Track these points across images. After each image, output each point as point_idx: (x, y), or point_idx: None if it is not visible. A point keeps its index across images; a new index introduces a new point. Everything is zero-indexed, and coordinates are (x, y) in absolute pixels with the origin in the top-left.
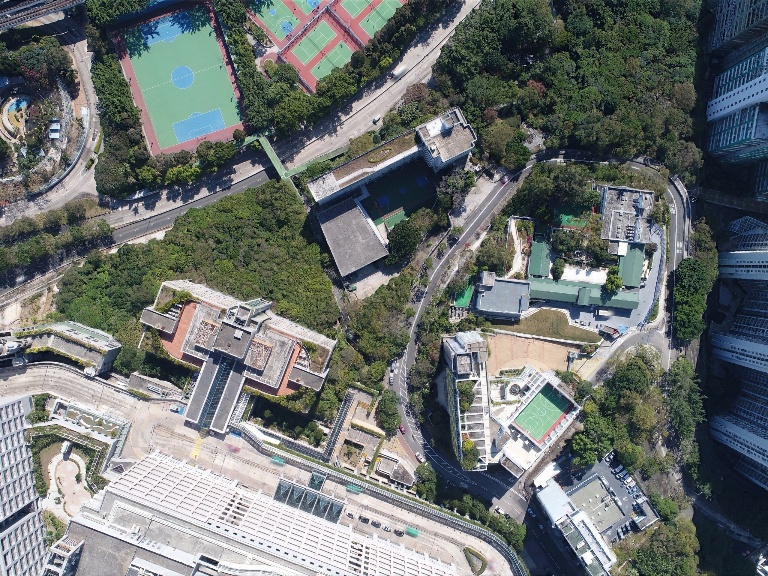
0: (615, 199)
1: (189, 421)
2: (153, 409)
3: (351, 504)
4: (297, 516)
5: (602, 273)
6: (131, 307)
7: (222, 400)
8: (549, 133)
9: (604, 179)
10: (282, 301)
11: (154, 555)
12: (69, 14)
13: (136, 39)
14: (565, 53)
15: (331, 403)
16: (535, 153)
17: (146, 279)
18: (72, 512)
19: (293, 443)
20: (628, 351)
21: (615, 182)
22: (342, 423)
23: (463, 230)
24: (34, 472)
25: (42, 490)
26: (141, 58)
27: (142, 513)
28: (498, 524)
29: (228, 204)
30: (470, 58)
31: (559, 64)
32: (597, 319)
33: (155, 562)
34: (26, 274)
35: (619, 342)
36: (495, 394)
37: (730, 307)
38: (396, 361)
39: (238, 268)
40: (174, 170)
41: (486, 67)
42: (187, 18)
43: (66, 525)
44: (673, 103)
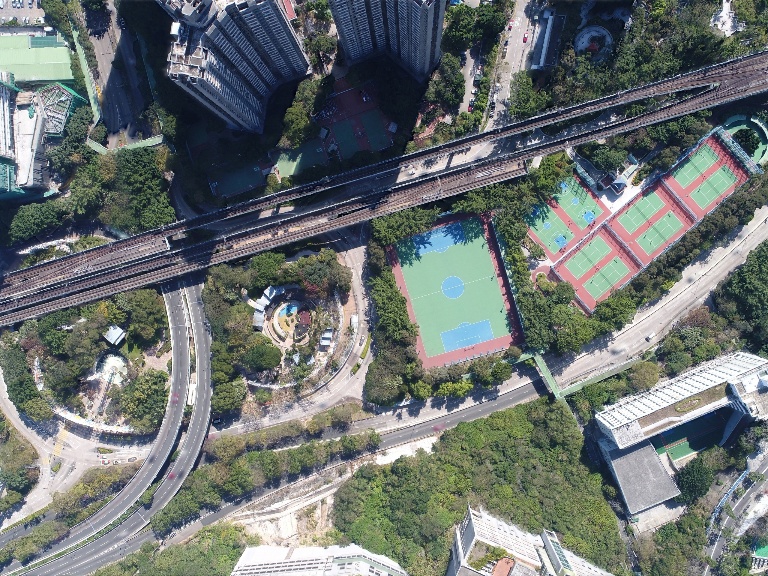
0: None
1: None
2: None
3: None
4: None
5: None
6: (421, 539)
7: None
8: None
9: None
10: (568, 535)
11: None
12: None
13: (408, 248)
14: None
15: None
16: None
17: (430, 505)
18: None
19: None
20: None
21: None
22: None
23: (759, 472)
24: None
25: None
26: (412, 267)
27: None
28: None
29: (501, 422)
30: (763, 290)
31: None
32: None
33: None
34: (290, 476)
35: None
36: None
37: None
38: None
39: (515, 491)
40: (450, 387)
41: None
42: (460, 229)
43: None
44: None
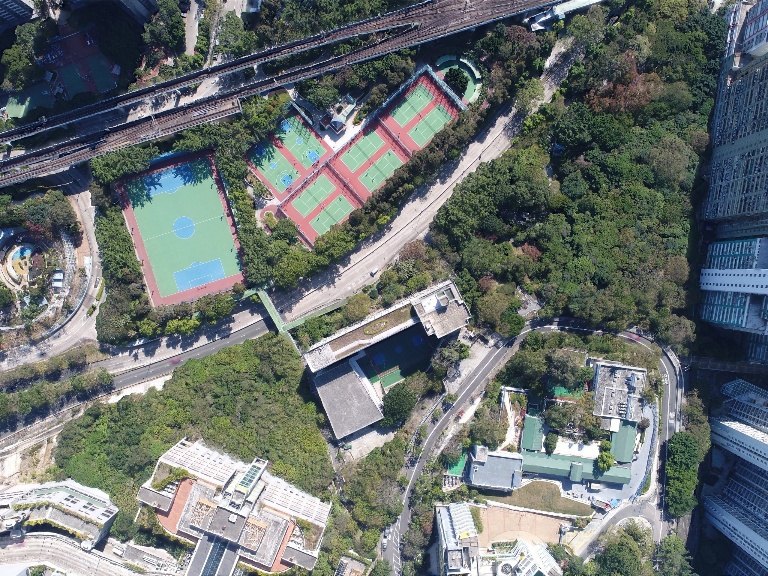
0: (608, 376)
1: None
2: None
3: None
4: None
5: (594, 447)
6: (129, 469)
7: None
8: (544, 300)
9: (597, 351)
10: (278, 462)
11: None
12: (74, 165)
13: (139, 190)
14: (560, 215)
15: (324, 571)
16: (529, 320)
17: (144, 438)
18: None
19: None
20: (620, 524)
21: (608, 356)
22: None
23: (457, 395)
24: None
25: None
26: (144, 208)
27: None
28: None
29: (226, 357)
30: (467, 221)
31: (554, 228)
32: (589, 491)
33: None
34: (27, 419)
35: (611, 514)
36: (487, 570)
37: (723, 470)
38: (389, 527)
39: (235, 423)
40: (174, 324)
41: (482, 229)
42: (189, 170)
43: None
44: (667, 270)
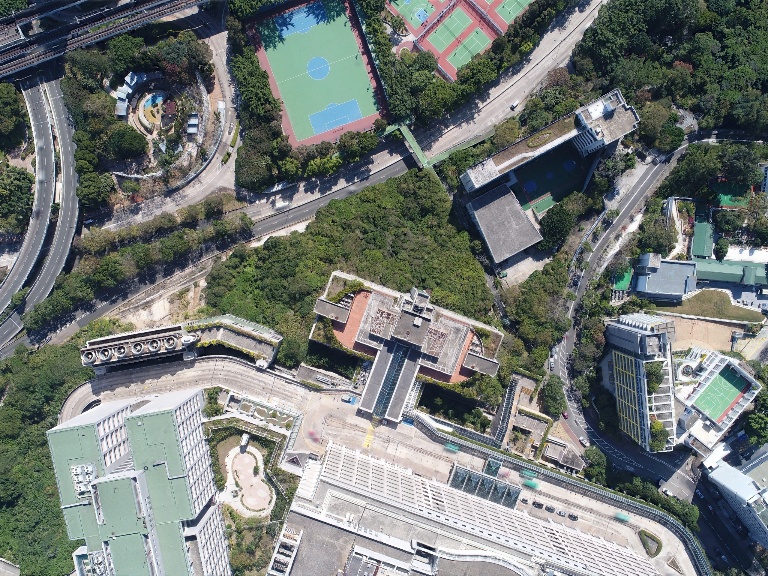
0: None
1: (361, 411)
2: (324, 400)
3: (524, 490)
4: (484, 502)
5: (765, 252)
6: (289, 299)
7: (397, 389)
8: (700, 113)
9: (762, 158)
10: (436, 289)
11: (373, 542)
12: (203, 8)
13: (271, 31)
14: (708, 33)
15: (495, 390)
16: (687, 134)
17: (299, 271)
18: (250, 505)
19: (465, 430)
20: None
21: None
22: (511, 409)
23: None
24: (212, 466)
25: (221, 483)
26: (276, 50)
27: (356, 501)
28: (673, 506)
29: (371, 194)
30: (615, 40)
31: None
32: (759, 298)
33: (374, 549)
34: (166, 270)
35: None
36: None
37: None
38: (555, 346)
39: (386, 258)
40: (317, 161)
41: (631, 49)
42: (322, 9)
43: (244, 518)
44: None
